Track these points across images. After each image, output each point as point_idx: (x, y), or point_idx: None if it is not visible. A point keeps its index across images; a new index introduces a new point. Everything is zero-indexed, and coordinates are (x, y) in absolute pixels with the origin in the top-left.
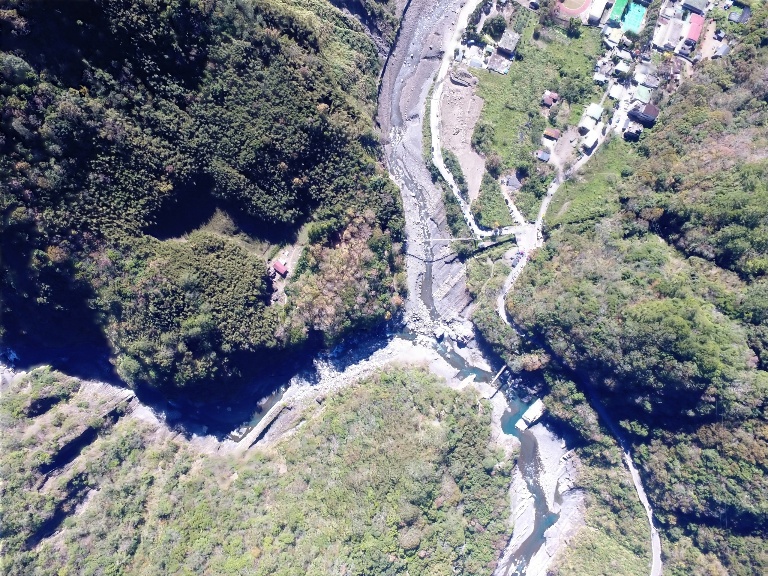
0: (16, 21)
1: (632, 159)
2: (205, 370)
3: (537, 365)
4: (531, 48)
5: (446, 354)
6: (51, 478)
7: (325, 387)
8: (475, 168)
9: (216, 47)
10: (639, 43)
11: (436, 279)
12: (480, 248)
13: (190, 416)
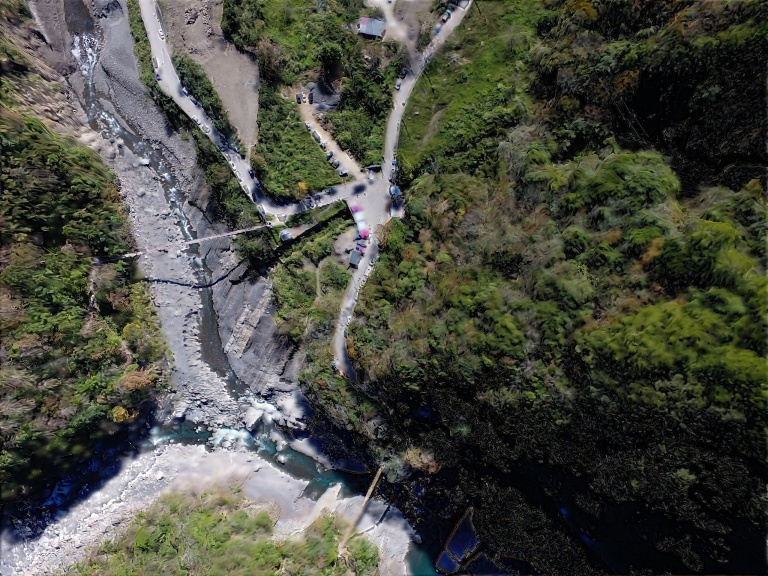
0: None
1: None
2: None
3: (434, 467)
4: None
5: (276, 456)
6: None
7: (43, 570)
8: (242, 82)
9: None
10: None
11: (223, 318)
12: (283, 242)
13: None
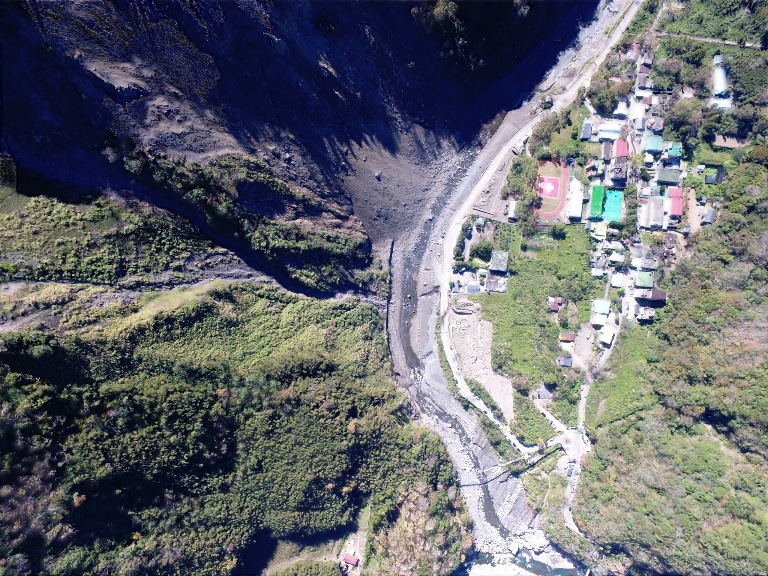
0: (65, 534)
1: (653, 343)
2: None
3: (623, 571)
4: (522, 261)
5: (526, 565)
6: None
7: None
8: (503, 390)
9: (242, 429)
10: (626, 231)
11: (496, 499)
12: (531, 465)
13: None
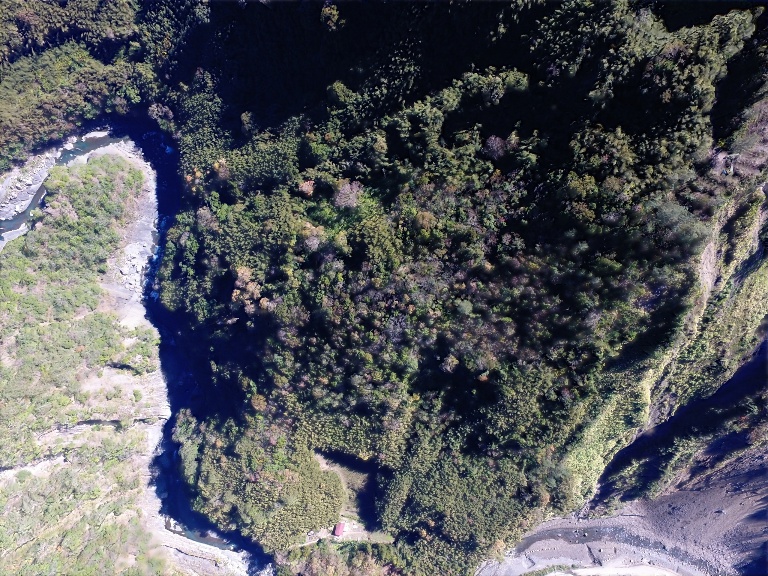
0: None
1: None
2: (216, 518)
3: None
4: None
5: None
6: (56, 431)
7: None
8: None
9: (509, 463)
10: None
11: None
12: None
13: (171, 475)
